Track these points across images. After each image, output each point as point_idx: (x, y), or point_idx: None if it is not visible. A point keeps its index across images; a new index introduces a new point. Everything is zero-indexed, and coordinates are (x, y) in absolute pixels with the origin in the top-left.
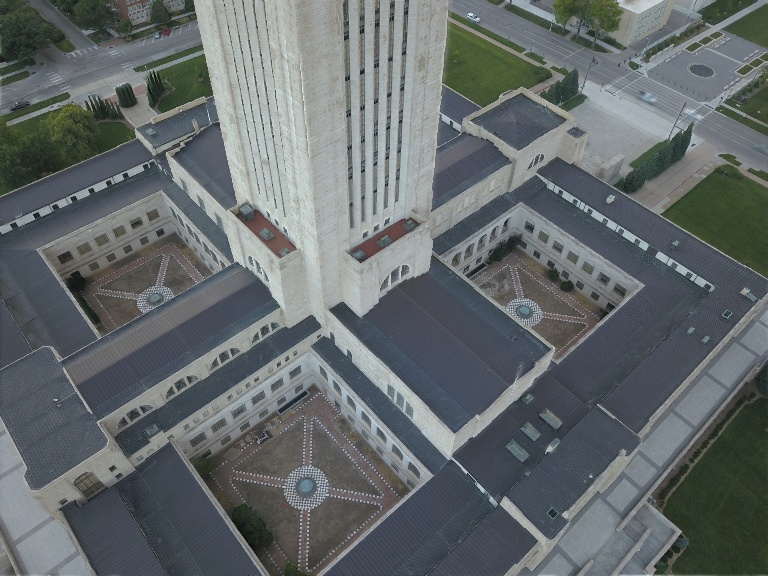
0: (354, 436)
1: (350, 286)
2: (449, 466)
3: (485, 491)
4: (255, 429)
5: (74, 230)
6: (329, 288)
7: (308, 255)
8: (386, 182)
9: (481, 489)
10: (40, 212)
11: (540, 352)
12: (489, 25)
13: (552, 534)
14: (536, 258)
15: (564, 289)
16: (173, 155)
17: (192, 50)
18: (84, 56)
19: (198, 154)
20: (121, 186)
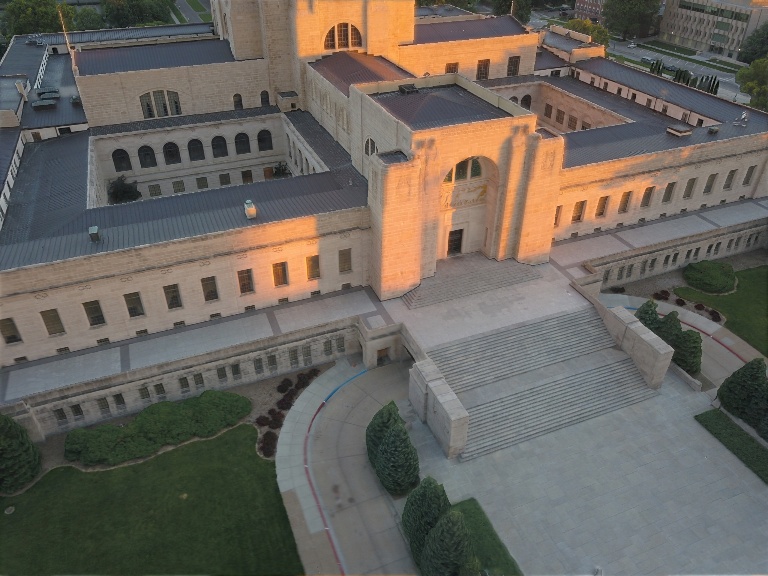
0: None
1: None
2: None
3: None
4: None
5: None
6: None
7: None
8: None
9: None
10: None
11: None
12: None
13: None
14: None
15: None
16: None
17: None
18: None
19: None
20: None
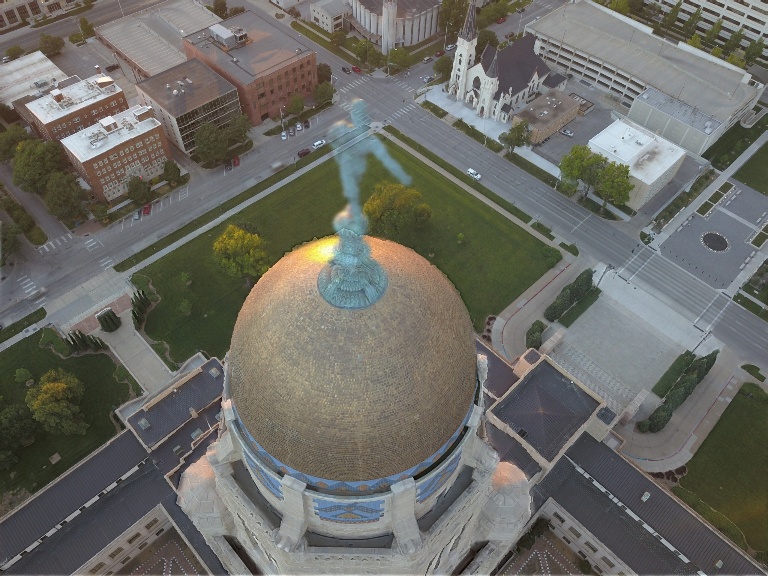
0: None
1: None
2: None
3: None
4: None
5: (67, 575)
6: None
7: None
8: None
9: None
10: (27, 549)
11: None
12: (491, 183)
13: None
14: (565, 541)
15: None
16: (172, 474)
17: (176, 236)
18: (58, 250)
19: None
20: (115, 494)
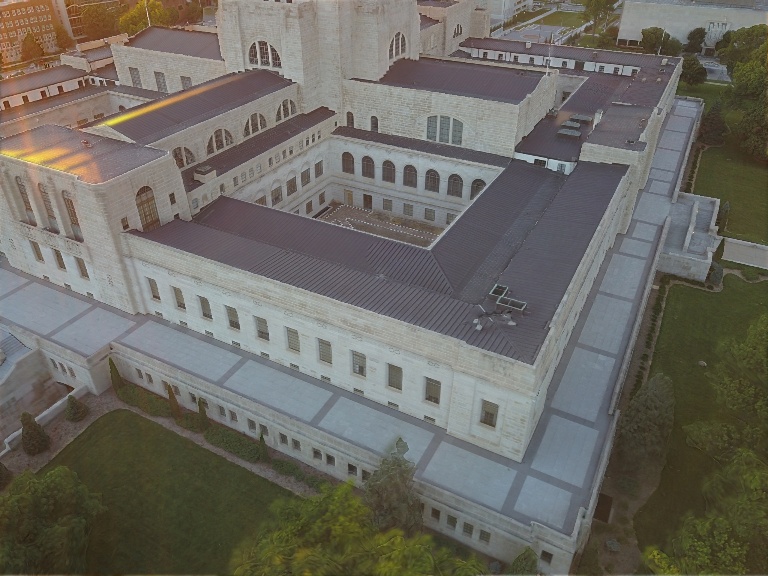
0: (395, 221)
1: (365, 40)
2: (514, 162)
3: (558, 165)
4: None
5: (19, 117)
6: (344, 47)
7: (323, 2)
8: None
9: (553, 167)
10: None
11: None
12: None
13: (640, 149)
14: None
15: None
16: None
17: None
18: None
19: (146, 44)
20: (57, 98)
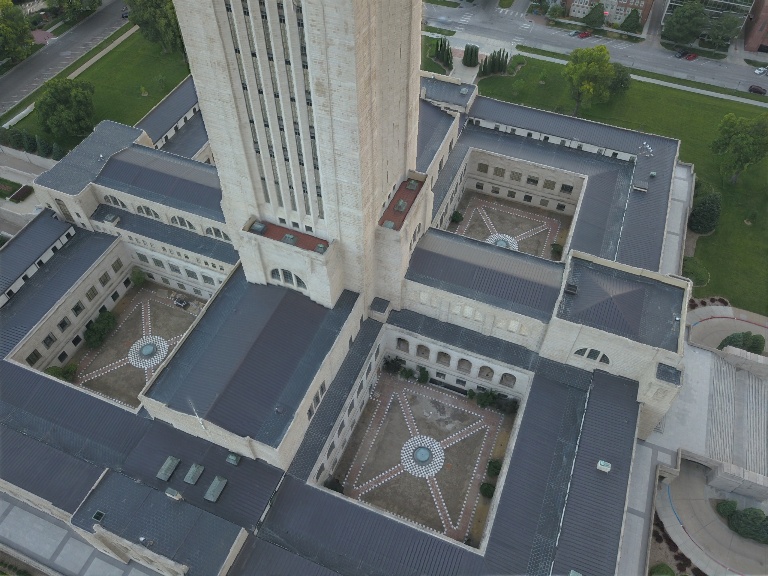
0: None
1: None
2: (150, 423)
3: None
4: (189, 296)
5: None
6: None
7: None
8: (306, 189)
9: None
10: None
11: (271, 440)
12: None
13: (77, 521)
14: None
15: (481, 488)
16: None
17: None
18: (505, 16)
19: None
20: None
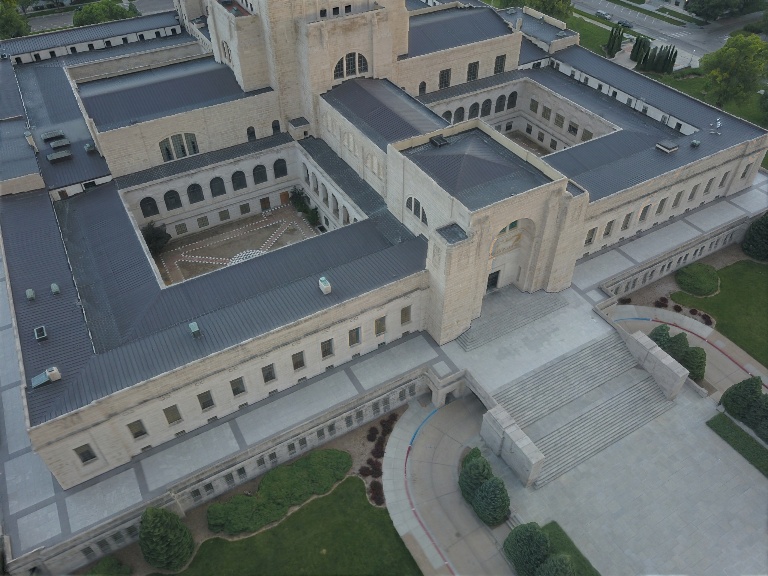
0: None
1: None
2: None
3: None
4: None
5: None
6: None
7: None
8: None
9: None
10: None
11: None
12: None
13: None
14: None
15: None
16: None
17: None
18: None
19: None
20: None
